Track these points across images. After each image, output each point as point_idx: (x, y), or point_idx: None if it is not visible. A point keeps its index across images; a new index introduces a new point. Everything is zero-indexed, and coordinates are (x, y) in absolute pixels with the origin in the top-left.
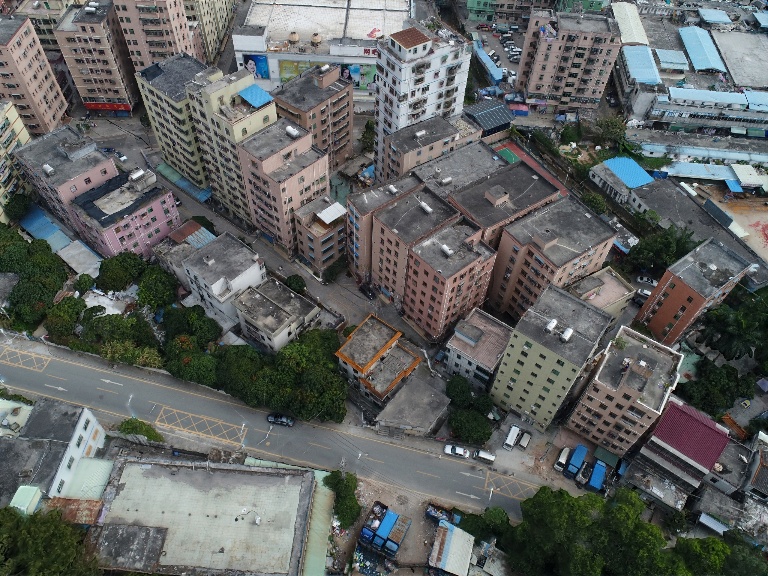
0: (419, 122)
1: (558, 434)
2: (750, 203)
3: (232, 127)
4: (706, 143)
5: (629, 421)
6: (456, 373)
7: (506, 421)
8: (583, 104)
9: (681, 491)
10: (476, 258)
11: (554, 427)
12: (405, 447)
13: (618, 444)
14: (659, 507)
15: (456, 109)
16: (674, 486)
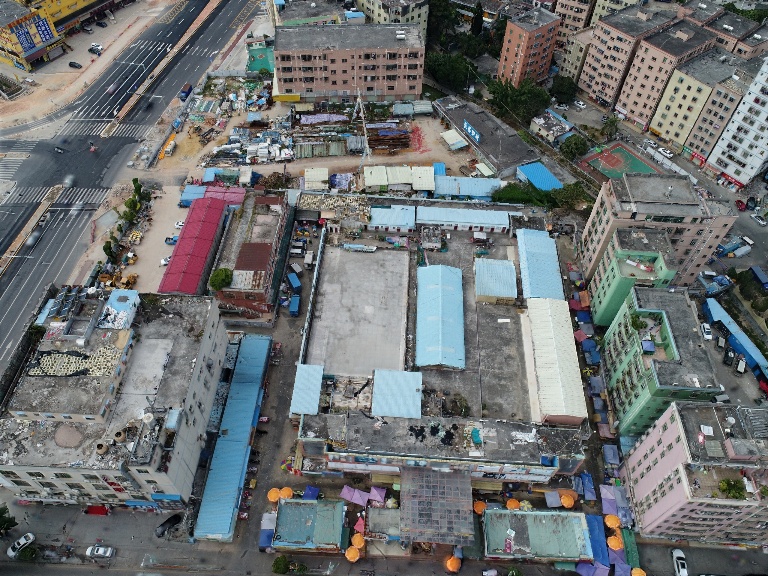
0: None
1: None
2: None
3: None
4: (456, 207)
5: None
6: None
7: None
8: None
9: None
10: None
11: None
12: None
13: None
14: None
15: None
16: None
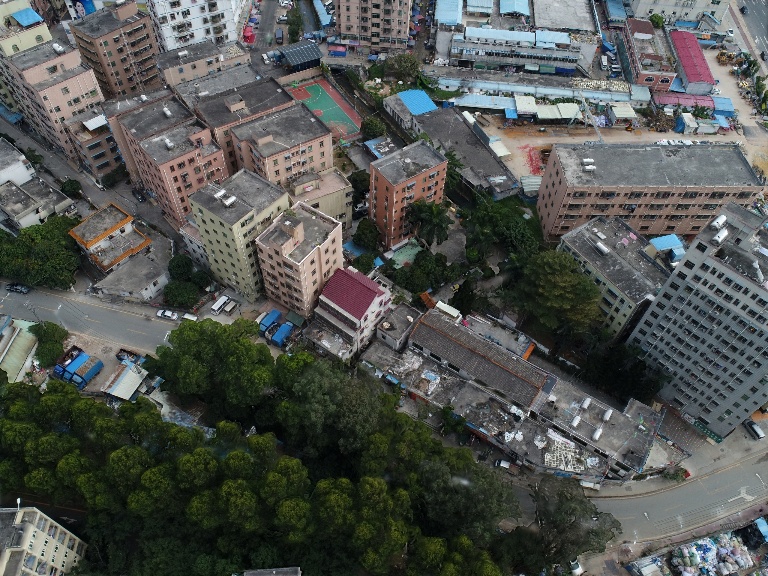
0: (189, 45)
1: (266, 304)
2: (526, 129)
3: None
4: (497, 78)
5: (291, 278)
6: (198, 260)
7: (222, 294)
8: (393, 44)
9: (347, 343)
10: (192, 150)
11: (263, 299)
12: (123, 311)
13: (298, 304)
14: (331, 358)
15: (230, 36)
16: (342, 339)
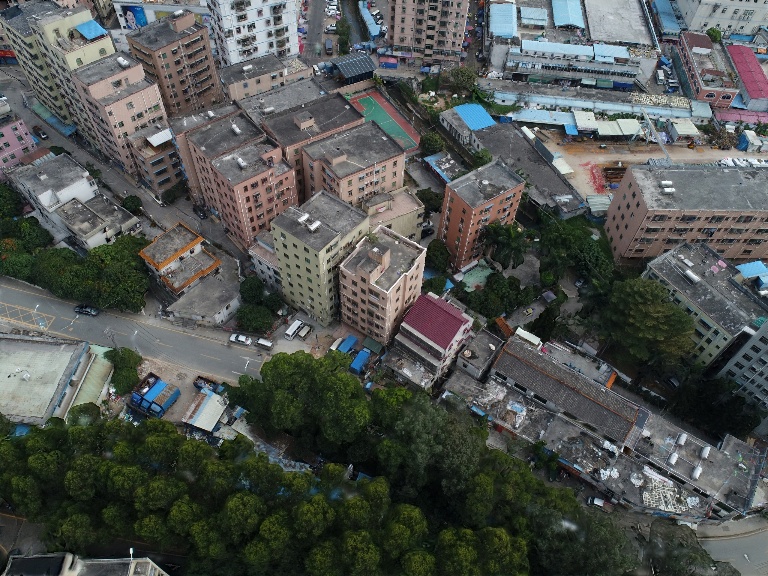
0: (252, 59)
1: (339, 329)
2: (586, 146)
3: (64, 56)
4: (555, 92)
5: (374, 305)
6: (265, 280)
7: (294, 317)
8: (446, 57)
9: (429, 372)
10: (266, 170)
11: (337, 323)
12: (195, 335)
13: (377, 331)
14: (411, 387)
15: (292, 49)
16: (423, 367)
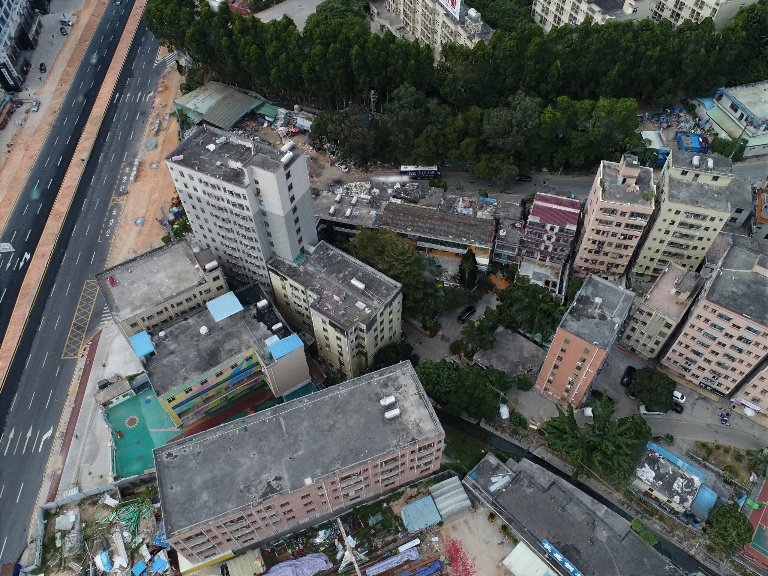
0: None
1: None
2: None
3: None
4: None
5: None
6: None
7: None
8: None
9: None
10: None
11: None
12: None
13: None
14: None
15: None
16: None
